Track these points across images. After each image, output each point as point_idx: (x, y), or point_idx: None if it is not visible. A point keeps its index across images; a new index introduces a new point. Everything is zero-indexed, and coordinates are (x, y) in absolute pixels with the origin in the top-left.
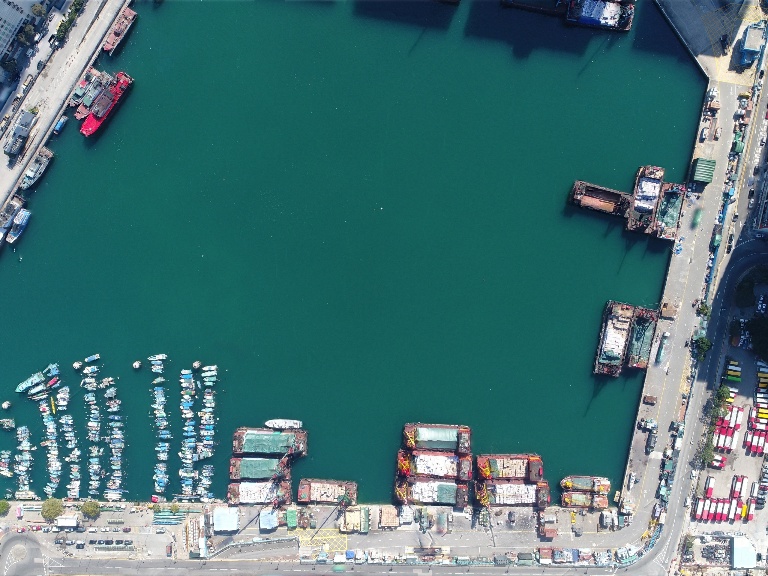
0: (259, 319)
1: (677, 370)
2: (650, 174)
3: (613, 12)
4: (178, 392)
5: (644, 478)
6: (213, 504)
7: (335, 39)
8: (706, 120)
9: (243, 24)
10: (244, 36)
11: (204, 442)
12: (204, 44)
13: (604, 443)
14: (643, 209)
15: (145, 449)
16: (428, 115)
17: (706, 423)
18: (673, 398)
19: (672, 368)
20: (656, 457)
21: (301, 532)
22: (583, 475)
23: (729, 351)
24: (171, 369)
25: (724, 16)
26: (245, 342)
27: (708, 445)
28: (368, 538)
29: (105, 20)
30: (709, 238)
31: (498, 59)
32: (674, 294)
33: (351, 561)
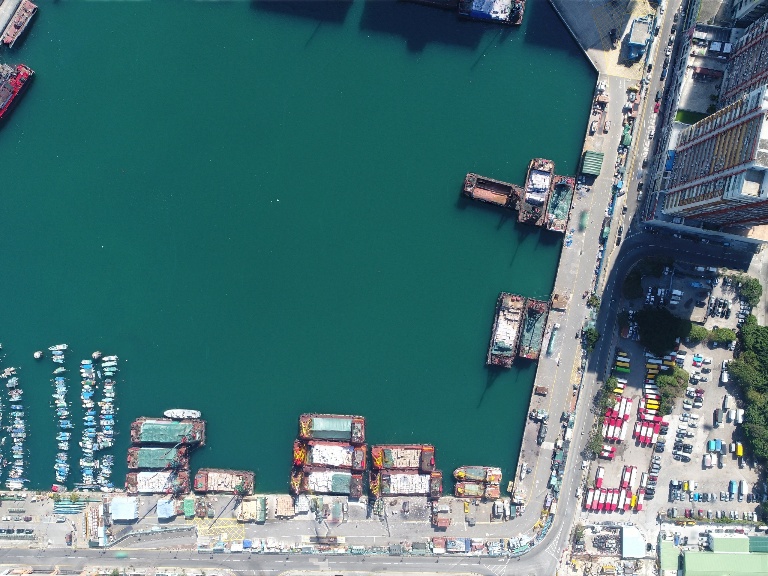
0: (158, 310)
1: (568, 361)
2: (539, 167)
3: (503, 6)
4: (79, 382)
5: (536, 468)
6: (113, 493)
7: (233, 32)
8: (596, 113)
9: (142, 17)
10: (143, 29)
11: (104, 432)
12: (104, 37)
13: (497, 433)
14: (535, 201)
15: (46, 439)
16: (324, 108)
17: (597, 414)
18: (564, 389)
19: (563, 359)
20: (548, 447)
21: (199, 521)
22: (476, 465)
23: (619, 342)
24: (72, 359)
25: (613, 10)
26: (144, 332)
27: (597, 435)
28: (265, 527)
29: (6, 13)
30: (599, 230)
31: (392, 52)
32: (565, 286)
33: (248, 550)
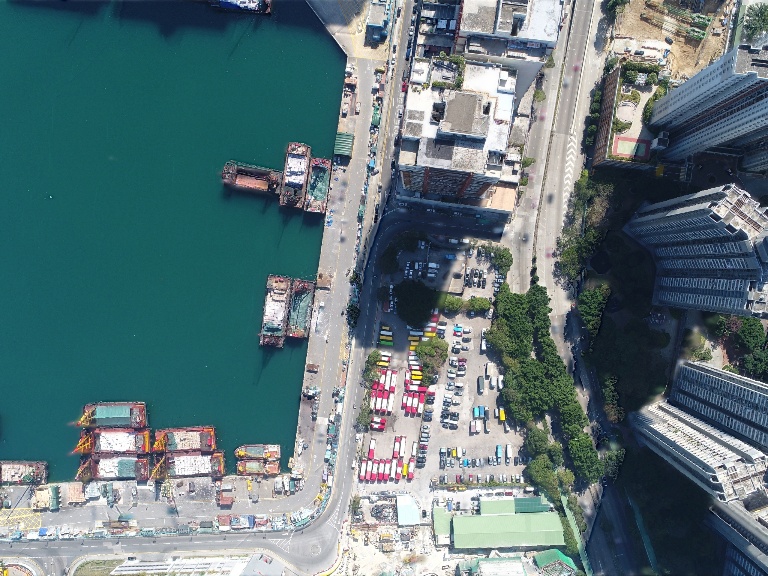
0: None
1: (336, 338)
2: (292, 150)
3: None
4: None
5: (313, 443)
6: None
7: None
8: (347, 96)
9: None
10: None
11: None
12: None
13: (274, 412)
14: (297, 185)
15: None
16: (90, 105)
17: (366, 387)
18: (334, 365)
19: (331, 336)
20: (322, 423)
21: None
22: (257, 444)
23: (383, 317)
24: None
25: None
26: None
27: None
28: (60, 515)
29: None
30: (357, 209)
31: (151, 47)
32: (328, 265)
33: (44, 538)
